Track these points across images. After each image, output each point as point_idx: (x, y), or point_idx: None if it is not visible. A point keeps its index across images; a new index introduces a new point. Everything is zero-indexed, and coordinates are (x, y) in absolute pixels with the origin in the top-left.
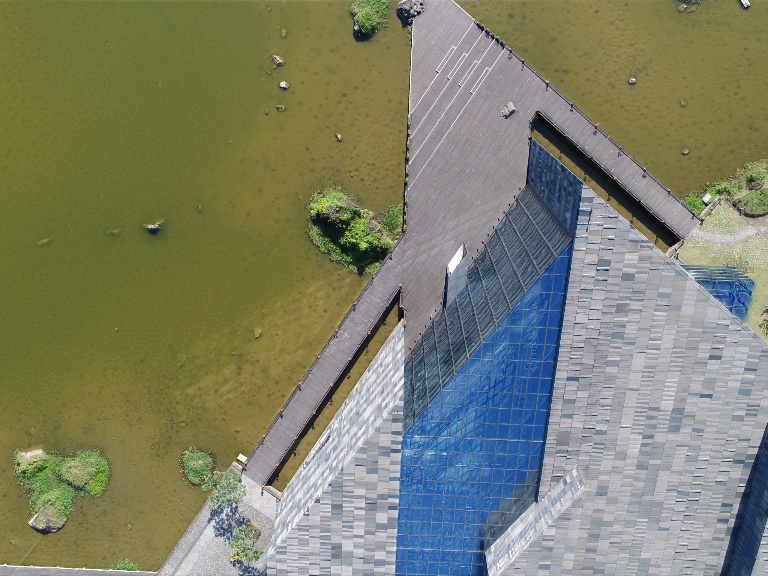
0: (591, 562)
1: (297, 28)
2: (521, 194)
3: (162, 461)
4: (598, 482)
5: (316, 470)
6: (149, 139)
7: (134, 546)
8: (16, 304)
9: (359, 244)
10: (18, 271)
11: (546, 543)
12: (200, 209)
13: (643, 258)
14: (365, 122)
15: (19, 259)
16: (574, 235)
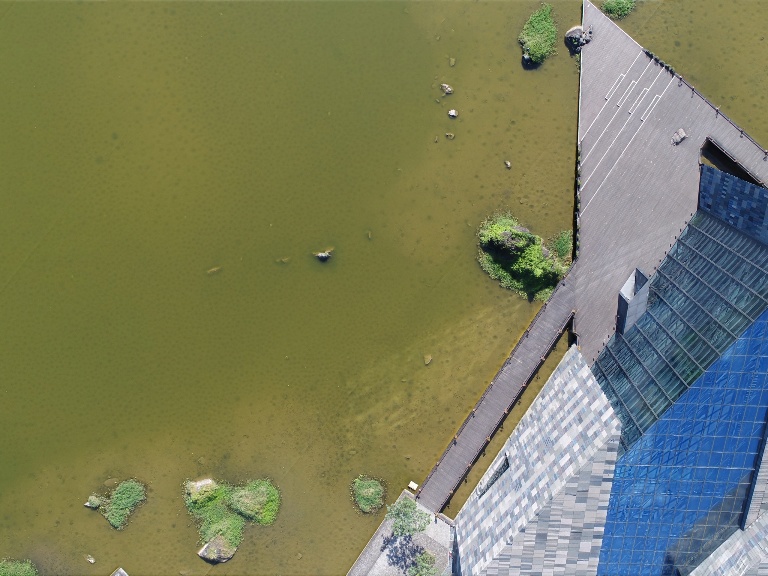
0: None
1: (466, 57)
2: (693, 220)
3: (332, 489)
4: None
5: (504, 498)
6: (318, 167)
7: (304, 575)
8: (185, 333)
9: (534, 271)
10: (187, 300)
11: (762, 571)
12: (370, 237)
13: None
14: (534, 149)
15: (188, 288)
16: None
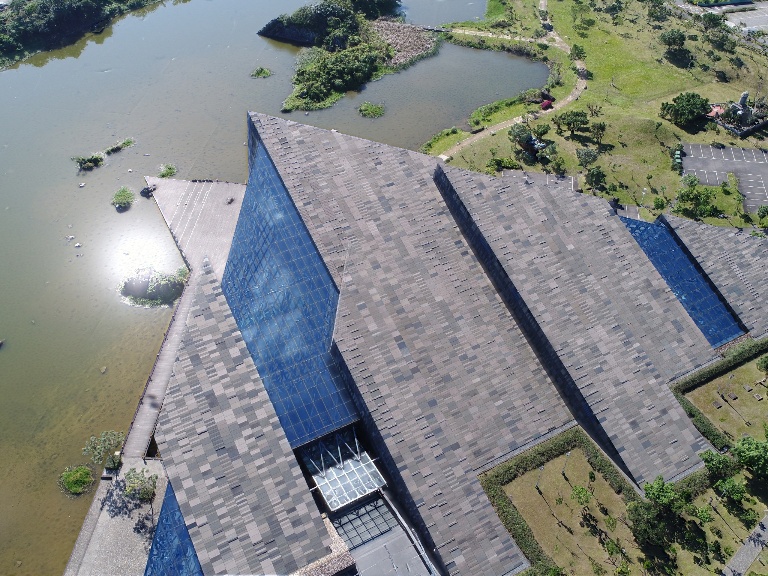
0: (407, 321)
1: (78, 221)
2: None
3: (41, 492)
4: (369, 260)
5: None
6: None
7: None
8: None
9: (161, 283)
10: None
11: (351, 288)
12: (34, 322)
13: (302, 131)
14: (141, 241)
15: None
16: (259, 135)
